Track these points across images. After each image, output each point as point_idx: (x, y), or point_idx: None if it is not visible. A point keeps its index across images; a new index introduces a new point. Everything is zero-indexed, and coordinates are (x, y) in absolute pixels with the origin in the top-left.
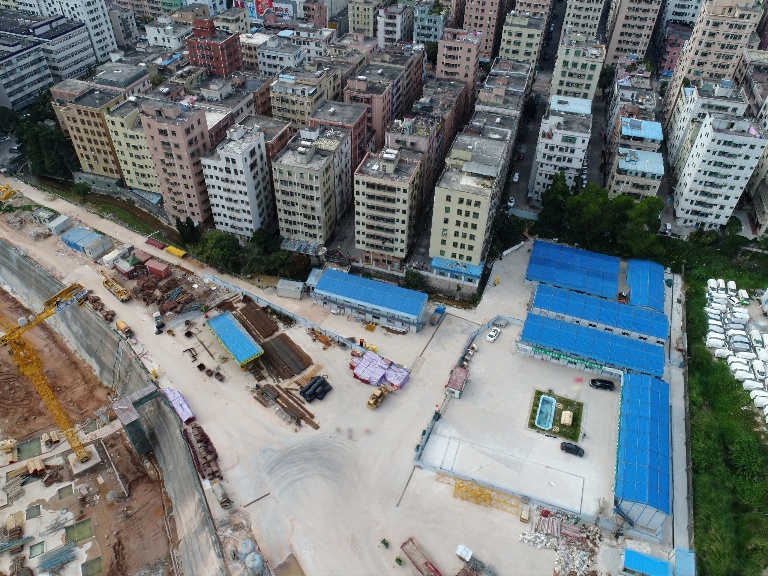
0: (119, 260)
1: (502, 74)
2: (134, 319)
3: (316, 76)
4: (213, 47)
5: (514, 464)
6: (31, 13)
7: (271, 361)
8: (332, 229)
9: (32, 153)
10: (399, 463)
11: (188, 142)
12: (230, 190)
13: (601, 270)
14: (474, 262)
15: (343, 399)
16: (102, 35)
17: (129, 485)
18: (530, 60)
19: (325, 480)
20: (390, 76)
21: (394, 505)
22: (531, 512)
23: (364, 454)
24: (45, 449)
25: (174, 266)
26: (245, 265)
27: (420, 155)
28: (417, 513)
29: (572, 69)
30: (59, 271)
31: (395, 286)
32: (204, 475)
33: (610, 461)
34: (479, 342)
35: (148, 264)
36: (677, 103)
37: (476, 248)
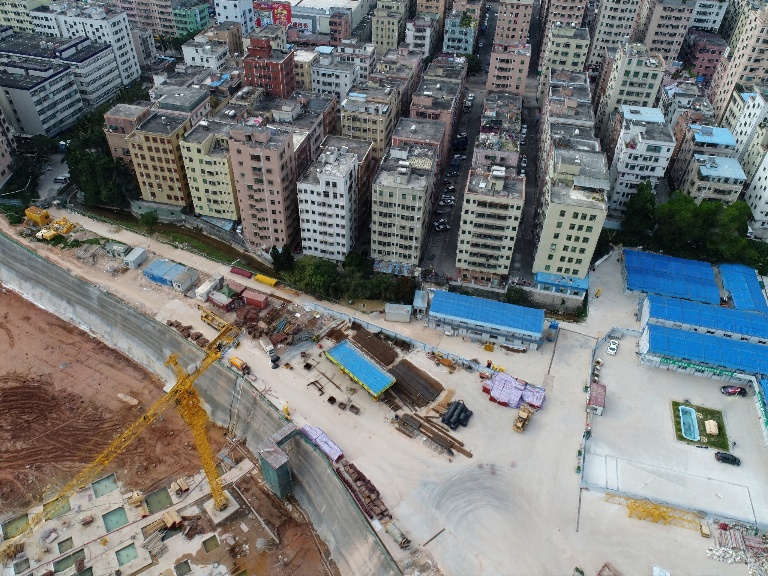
0: (214, 292)
1: (562, 85)
2: (245, 354)
3: (386, 93)
4: (272, 67)
5: (677, 478)
6: (49, 35)
7: (401, 389)
8: (422, 248)
9: (87, 183)
10: (564, 486)
11: (281, 167)
12: (326, 214)
13: (697, 276)
14: (580, 275)
15: (486, 424)
16: (126, 56)
17: (277, 531)
18: (577, 70)
19: (496, 510)
20: (449, 90)
21: (574, 531)
22: (709, 526)
23: (527, 480)
24: (176, 499)
25: (269, 295)
26: (347, 290)
27: (513, 170)
28: (599, 537)
29: (633, 78)
30: (149, 307)
31: (509, 304)
32: (372, 515)
33: (766, 468)
34: (601, 356)
35: (245, 295)
36: (729, 108)
37: (585, 261)
